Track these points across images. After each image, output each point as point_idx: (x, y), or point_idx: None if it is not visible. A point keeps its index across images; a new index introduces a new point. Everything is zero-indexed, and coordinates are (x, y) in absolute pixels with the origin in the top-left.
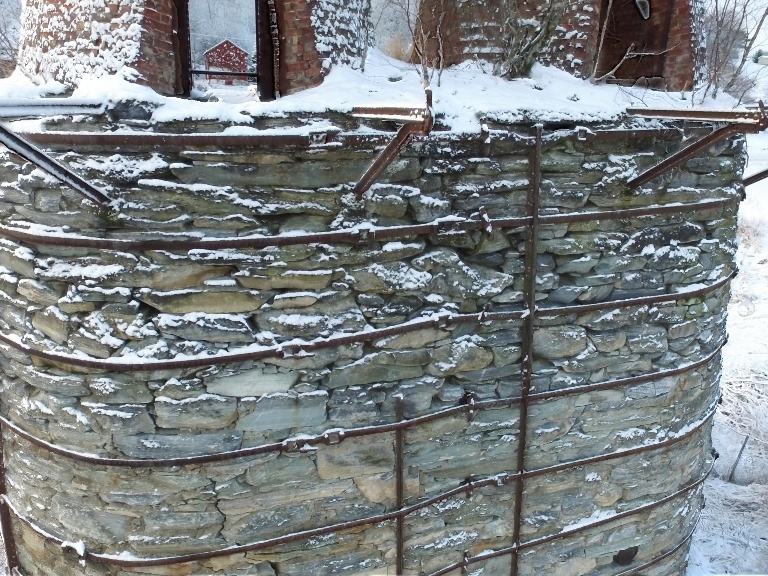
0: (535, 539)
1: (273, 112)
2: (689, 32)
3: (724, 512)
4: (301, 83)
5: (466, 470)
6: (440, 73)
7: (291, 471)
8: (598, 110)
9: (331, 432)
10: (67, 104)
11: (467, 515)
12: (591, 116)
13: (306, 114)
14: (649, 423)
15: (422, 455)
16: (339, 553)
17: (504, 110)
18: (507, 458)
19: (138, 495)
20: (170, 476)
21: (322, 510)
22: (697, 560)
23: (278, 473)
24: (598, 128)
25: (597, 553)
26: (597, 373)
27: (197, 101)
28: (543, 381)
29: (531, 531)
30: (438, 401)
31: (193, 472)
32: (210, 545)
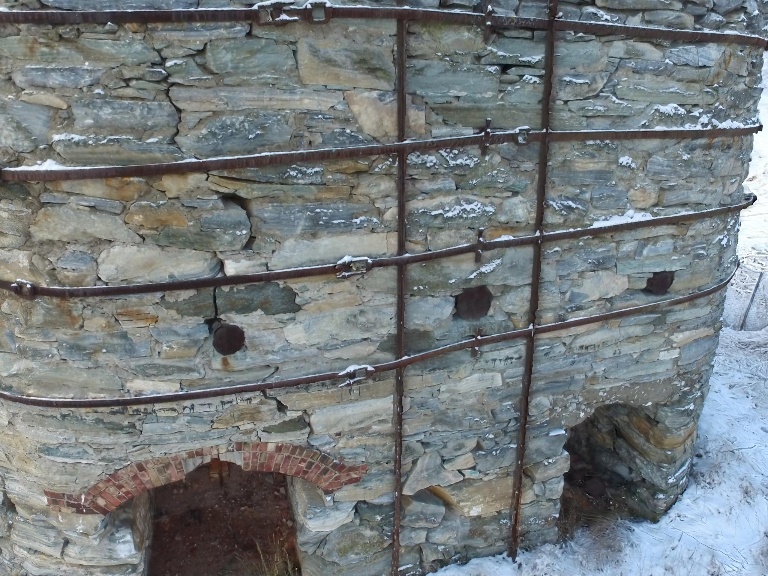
0: (561, 230)
1: None
2: None
3: (739, 351)
4: None
5: (481, 115)
6: None
7: (264, 61)
8: None
9: (315, 2)
10: None
11: (482, 179)
12: None
13: None
14: (690, 103)
15: (428, 76)
16: (327, 200)
17: None
18: (529, 110)
19: (63, 69)
20: (104, 40)
21: (305, 130)
22: (716, 386)
23: (248, 62)
24: None
25: (630, 269)
26: (633, 17)
27: None
28: (572, 10)
29: (556, 220)
30: (447, 7)
31: (135, 35)
32: (161, 153)
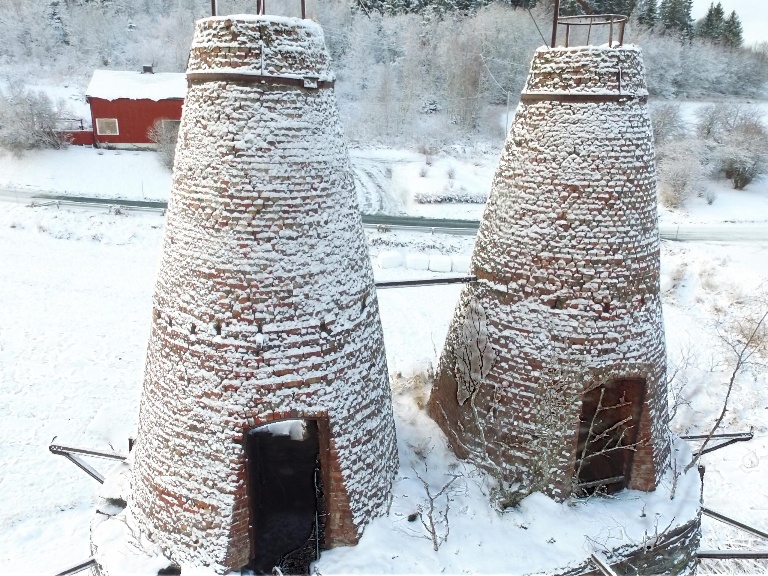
0: None
1: None
2: (651, 450)
3: None
4: (341, 541)
5: None
6: (446, 535)
7: None
8: (569, 561)
9: None
10: None
11: None
12: (563, 569)
13: None
14: None
15: None
16: None
17: None
18: None
19: None
20: None
21: None
22: None
23: None
24: (568, 575)
25: None
26: None
27: None
28: None
29: None
30: None
31: None
32: None
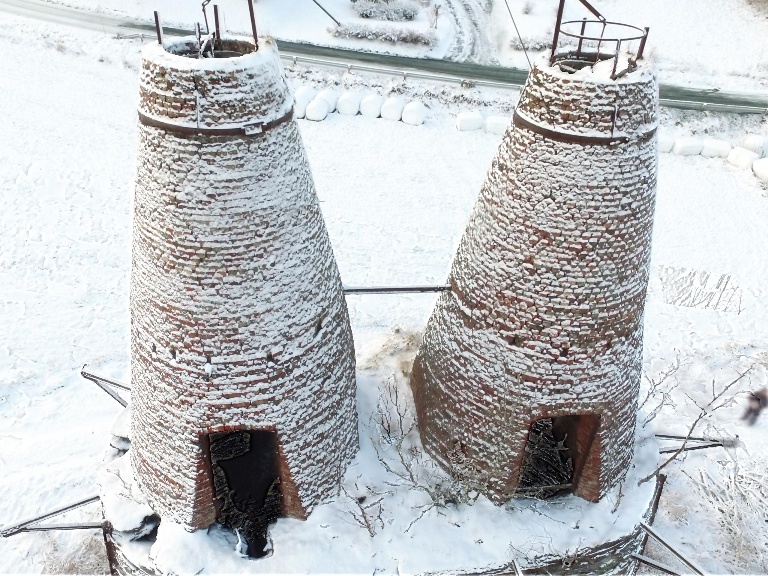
0: None
1: None
2: (598, 472)
3: None
4: (294, 515)
5: None
6: None
7: None
8: (489, 563)
9: None
10: None
11: None
12: (482, 569)
13: None
14: None
15: None
16: None
17: (414, 574)
18: None
19: None
20: None
21: None
22: None
23: None
24: (487, 573)
25: None
26: None
27: (223, 561)
28: None
29: None
30: None
31: None
32: None
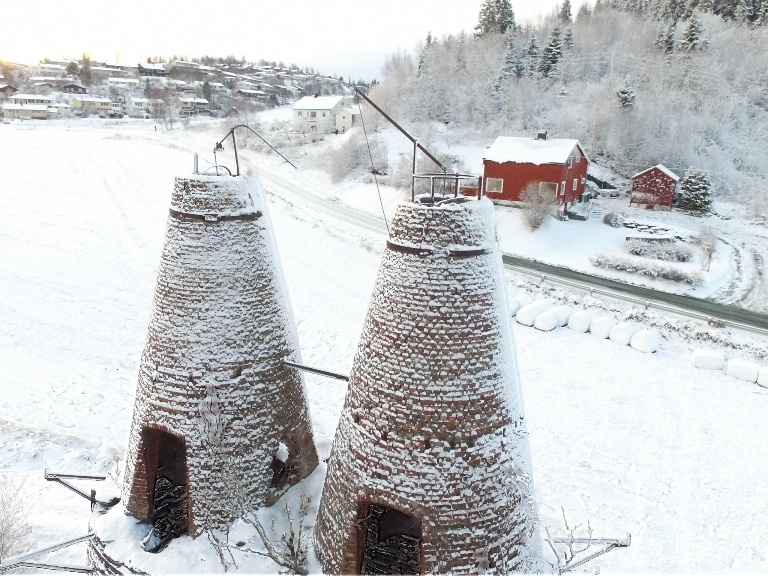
0: None
1: (135, 568)
2: None
3: None
4: None
5: None
6: None
7: None
8: None
9: None
10: (71, 541)
11: None
12: None
13: (148, 574)
14: None
15: None
16: None
17: None
18: None
19: None
20: None
21: None
22: None
23: None
24: None
25: None
26: None
27: (128, 541)
28: None
29: None
30: None
31: None
32: None
